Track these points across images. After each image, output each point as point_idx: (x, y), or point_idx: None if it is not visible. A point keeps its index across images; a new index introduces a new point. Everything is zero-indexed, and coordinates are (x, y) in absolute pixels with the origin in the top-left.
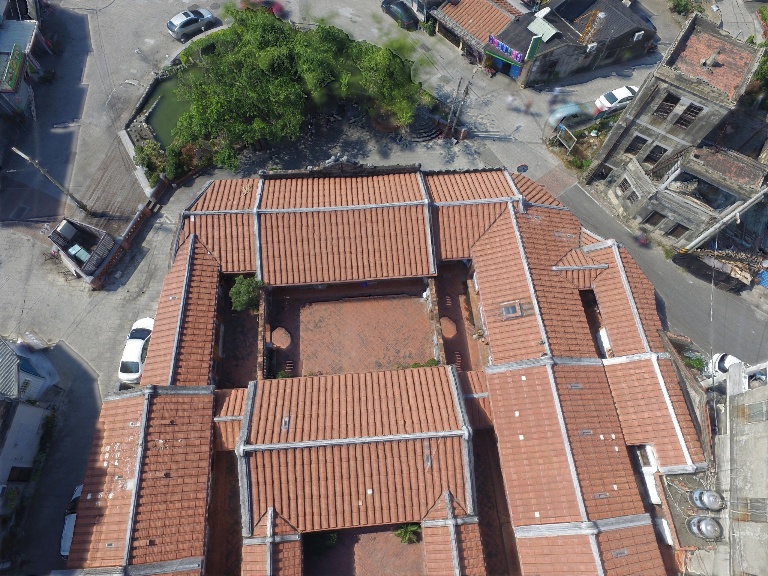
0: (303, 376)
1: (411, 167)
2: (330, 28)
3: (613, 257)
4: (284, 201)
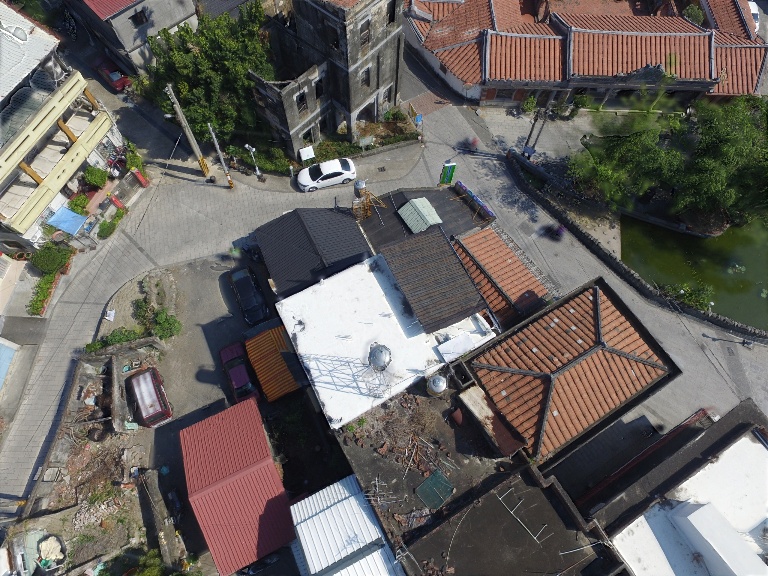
0: (628, 1)
1: (581, 75)
2: (713, 172)
3: (415, 3)
4: (690, 49)
